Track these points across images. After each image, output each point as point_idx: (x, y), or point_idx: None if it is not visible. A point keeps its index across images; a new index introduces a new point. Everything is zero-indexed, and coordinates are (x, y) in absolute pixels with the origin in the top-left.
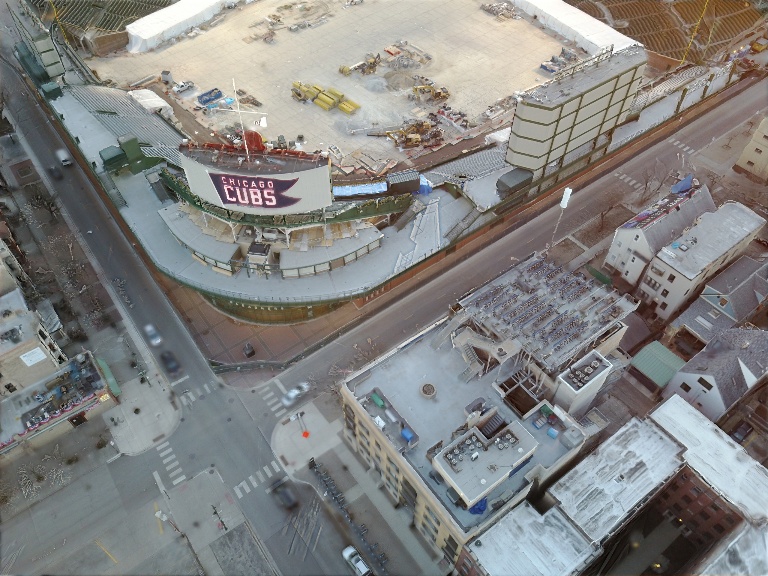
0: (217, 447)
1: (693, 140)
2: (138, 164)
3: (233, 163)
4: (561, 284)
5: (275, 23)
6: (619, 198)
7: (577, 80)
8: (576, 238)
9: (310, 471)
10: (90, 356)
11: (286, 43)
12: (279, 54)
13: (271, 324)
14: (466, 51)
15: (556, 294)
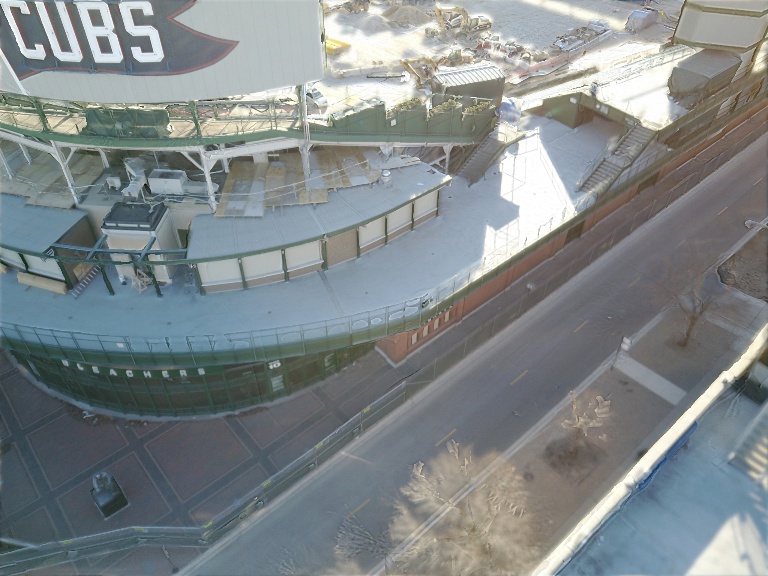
0: None
1: None
2: None
3: None
4: None
5: None
6: None
7: None
8: None
9: None
10: None
11: None
12: None
13: (178, 415)
14: None
15: None
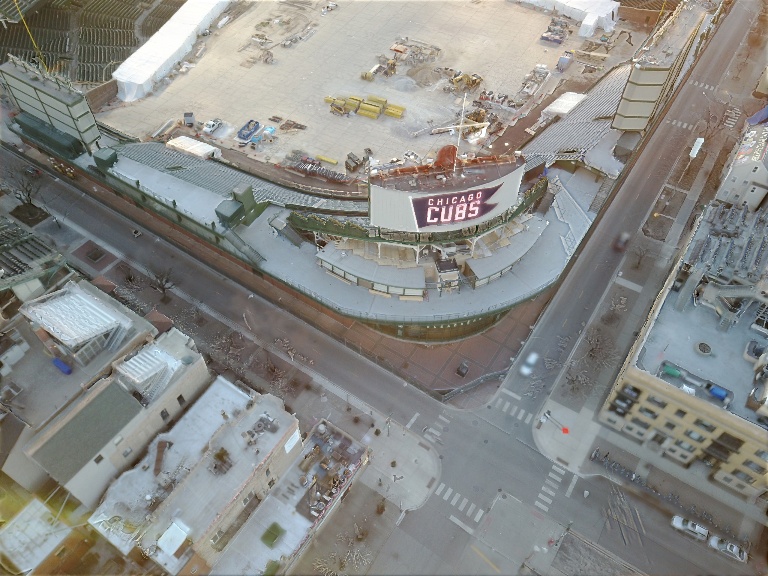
0: (493, 471)
1: (708, 78)
2: (252, 213)
3: (436, 183)
4: (759, 222)
5: (264, 42)
6: (684, 141)
7: (667, 39)
8: (673, 185)
9: (592, 463)
10: (329, 423)
11: (288, 60)
12: (289, 73)
13: (463, 338)
14: (466, 36)
15: (767, 232)
